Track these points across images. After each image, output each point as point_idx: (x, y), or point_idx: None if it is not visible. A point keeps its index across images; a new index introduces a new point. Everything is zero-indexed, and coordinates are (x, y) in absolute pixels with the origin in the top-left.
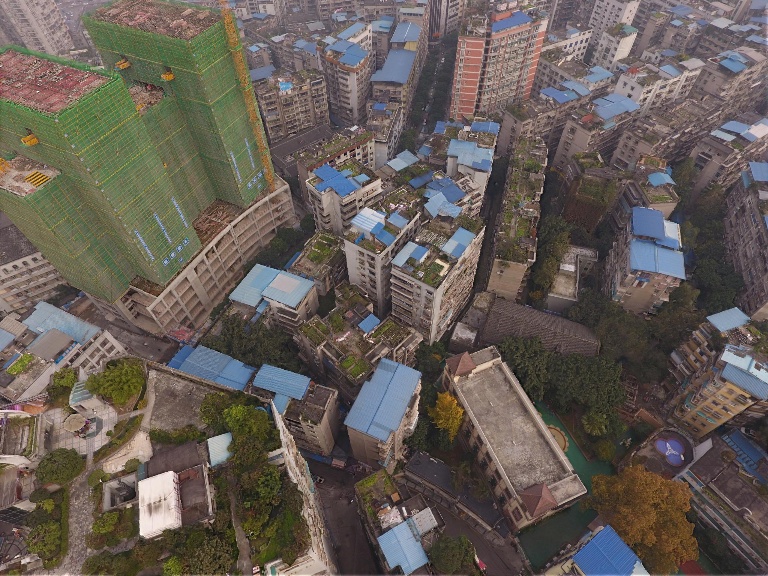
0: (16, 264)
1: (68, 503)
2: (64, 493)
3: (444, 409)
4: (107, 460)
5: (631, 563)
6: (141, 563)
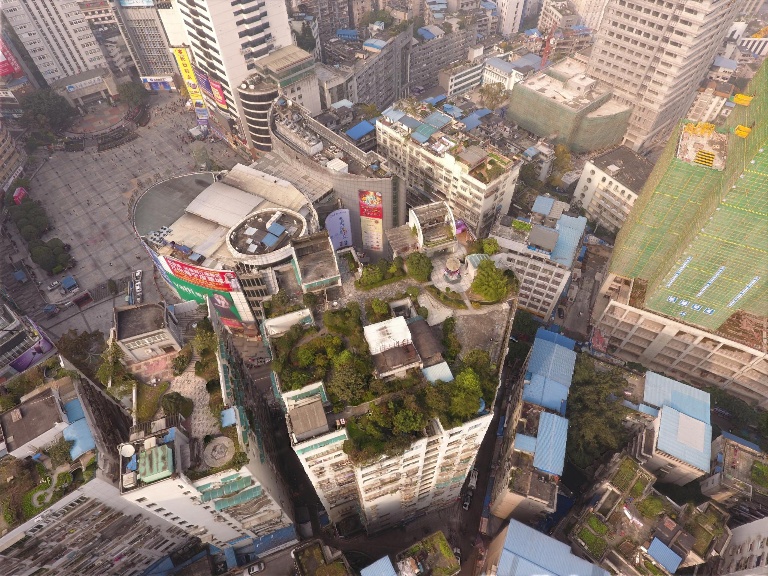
0: (626, 191)
1: (396, 281)
2: (403, 276)
3: None
4: (428, 295)
5: None
6: None
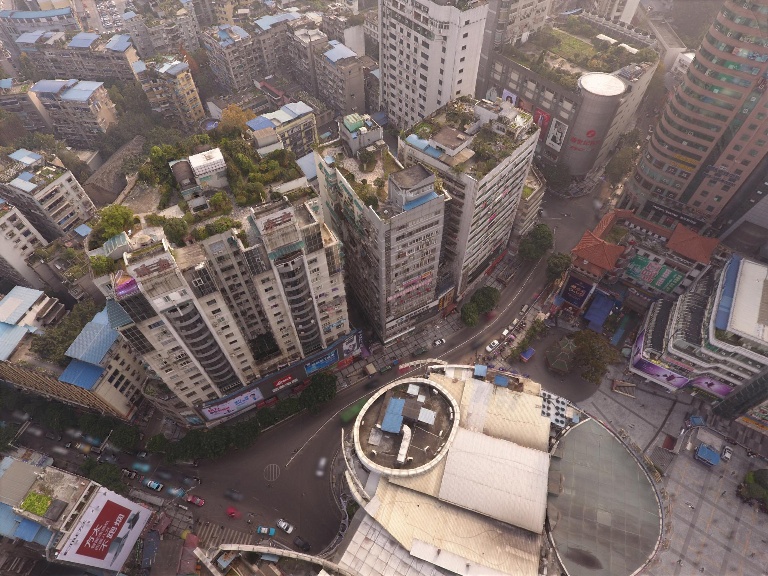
0: None
1: None
2: None
3: None
4: None
5: (262, 117)
6: (239, 174)
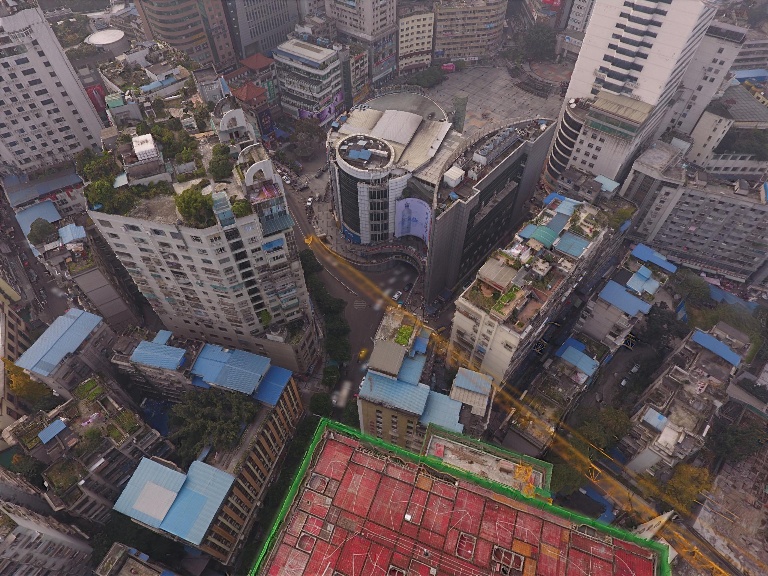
0: None
1: None
2: None
3: (26, 376)
4: None
5: None
6: None
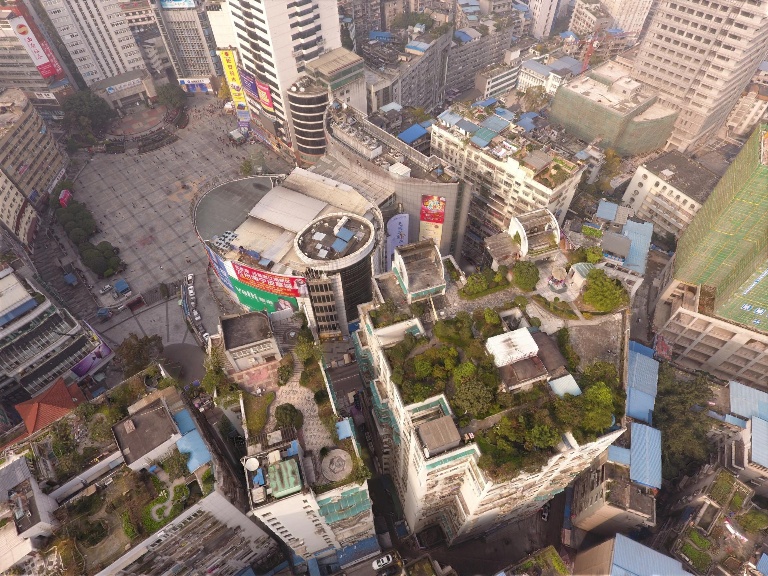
0: (681, 196)
1: (500, 290)
2: (507, 285)
3: None
4: (535, 305)
5: None
6: (468, 347)
